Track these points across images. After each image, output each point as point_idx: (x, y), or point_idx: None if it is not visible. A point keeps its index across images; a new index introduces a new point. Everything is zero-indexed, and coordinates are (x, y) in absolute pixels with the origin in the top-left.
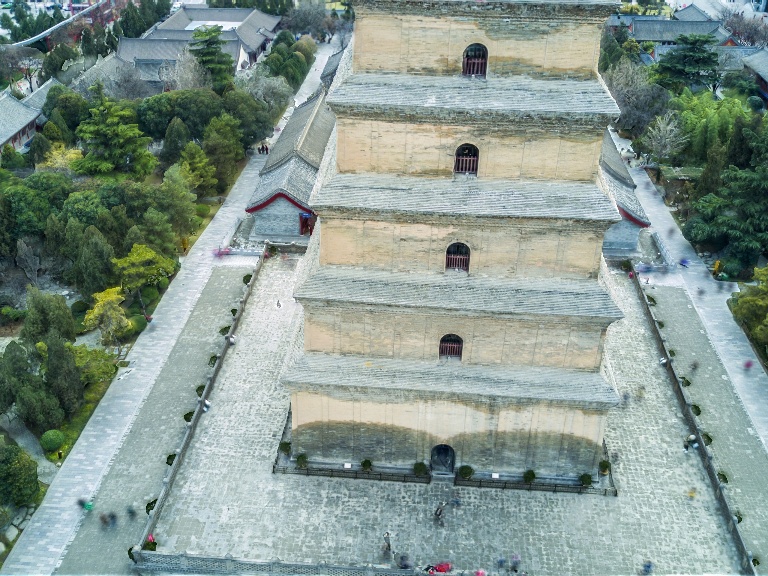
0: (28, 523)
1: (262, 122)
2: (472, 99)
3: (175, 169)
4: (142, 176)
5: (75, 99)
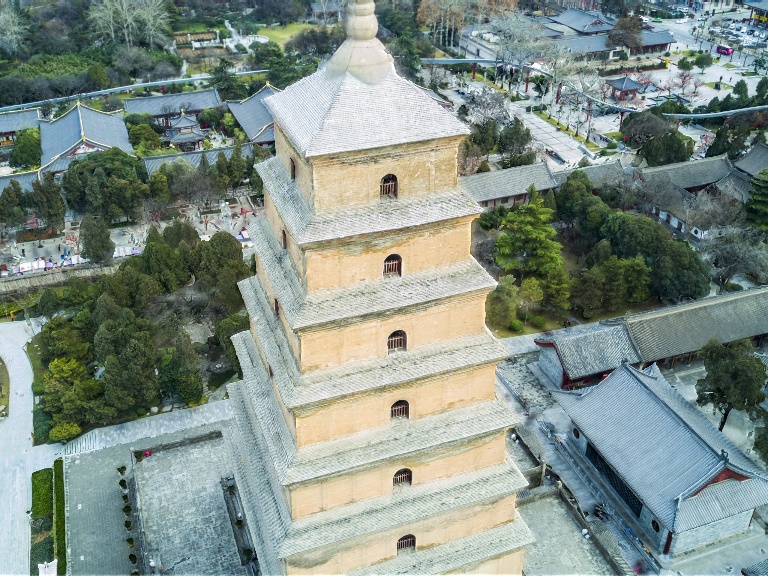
0: (177, 410)
1: (682, 281)
2: (264, 333)
3: (506, 278)
4: (534, 271)
5: (573, 188)
